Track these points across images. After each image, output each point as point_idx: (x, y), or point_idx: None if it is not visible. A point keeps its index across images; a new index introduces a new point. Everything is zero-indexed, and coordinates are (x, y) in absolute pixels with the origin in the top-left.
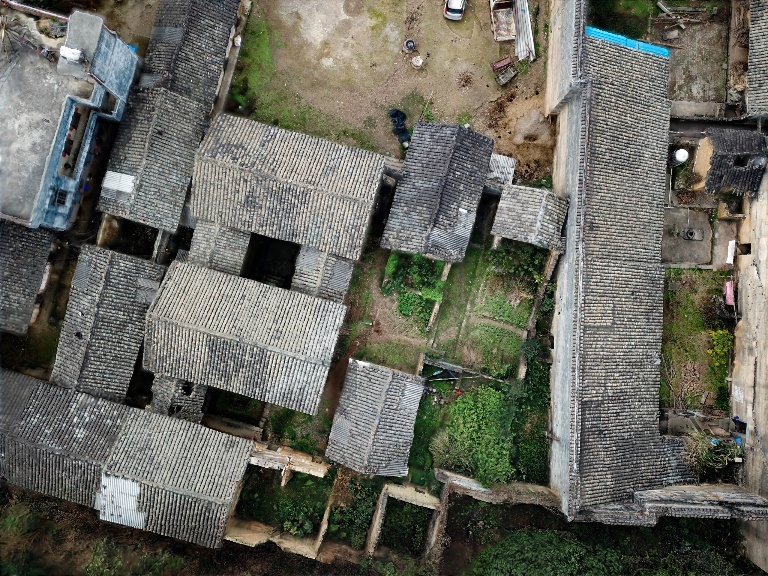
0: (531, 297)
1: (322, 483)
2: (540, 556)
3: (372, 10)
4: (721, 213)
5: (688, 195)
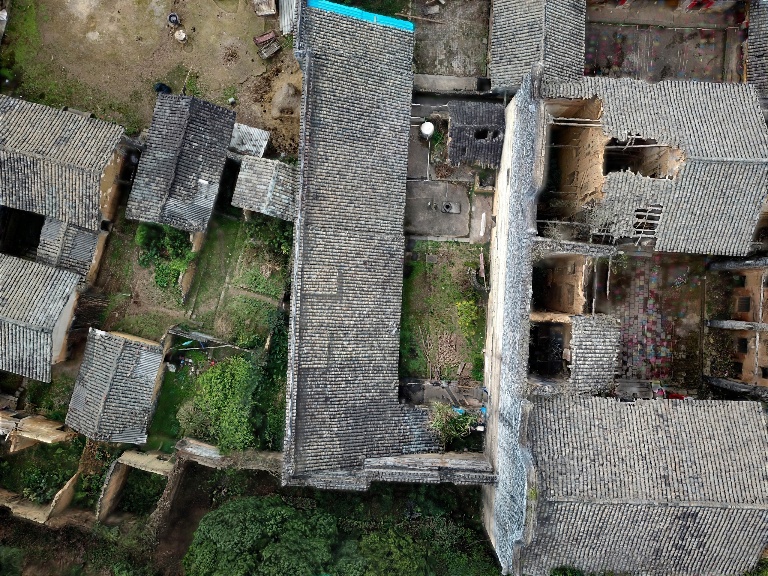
0: (278, 268)
1: (73, 451)
2: (234, 517)
3: None
4: (475, 186)
5: (443, 168)
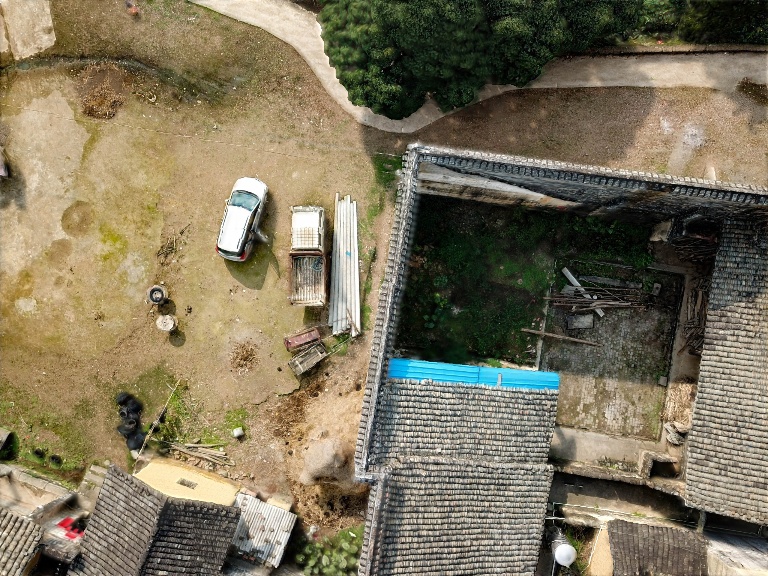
0: None
1: None
2: None
3: (107, 229)
4: None
5: None
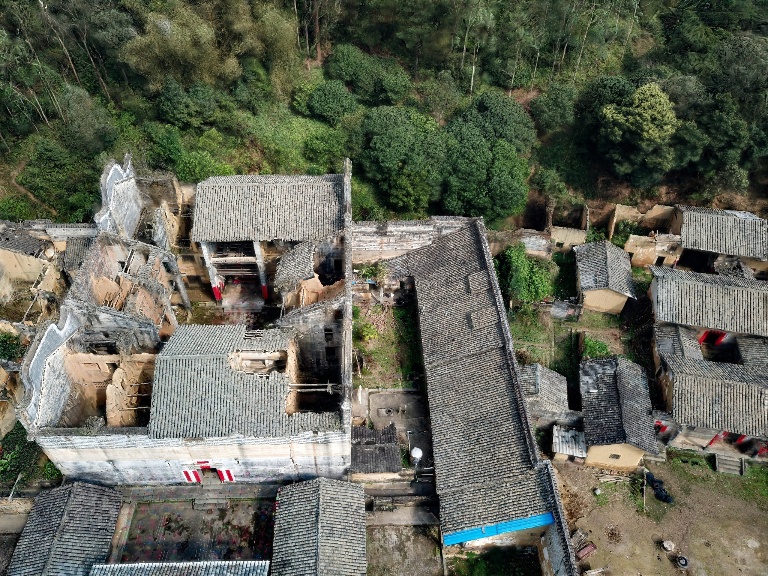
0: (517, 349)
1: None
2: None
3: None
4: None
5: None
